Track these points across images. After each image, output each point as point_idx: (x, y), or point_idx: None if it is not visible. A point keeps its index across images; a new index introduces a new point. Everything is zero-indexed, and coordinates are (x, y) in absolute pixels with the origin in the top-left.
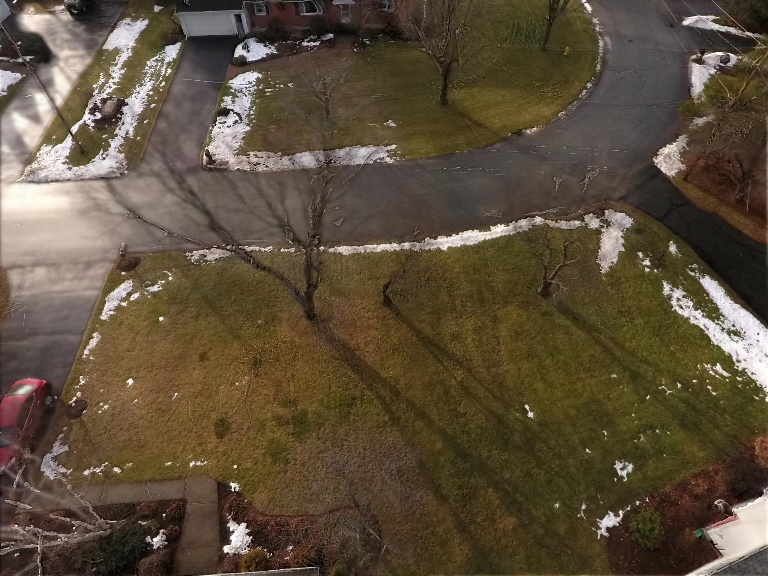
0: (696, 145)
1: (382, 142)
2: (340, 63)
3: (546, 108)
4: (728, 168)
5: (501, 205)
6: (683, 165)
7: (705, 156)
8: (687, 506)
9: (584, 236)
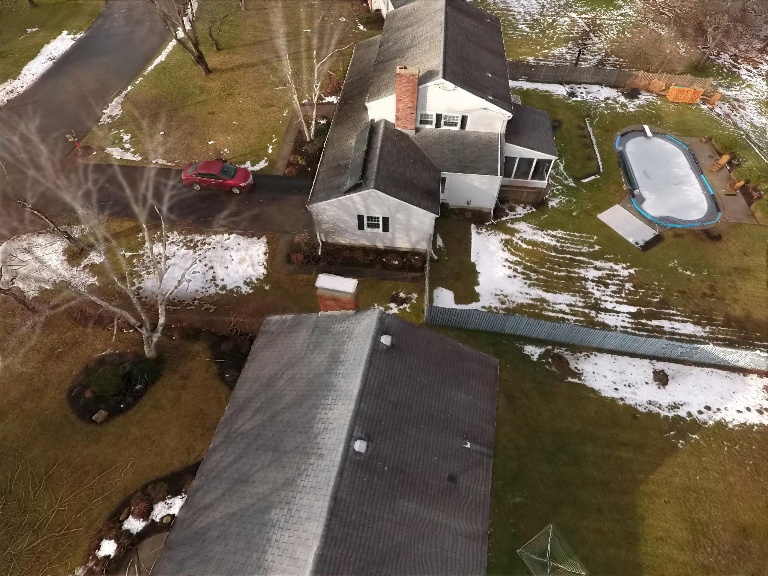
0: None
1: (53, 35)
2: None
3: None
4: None
5: (170, 7)
6: None
7: None
8: (362, 8)
9: None
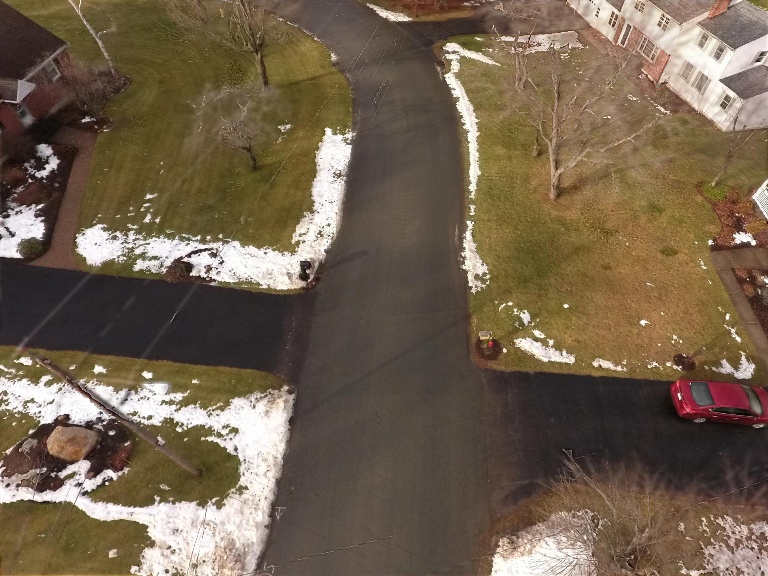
0: (380, 4)
1: (317, 136)
2: (129, 147)
3: (306, 43)
4: (410, 1)
5: (430, 87)
6: (400, 13)
7: (393, 4)
8: (650, 82)
9: (468, 62)
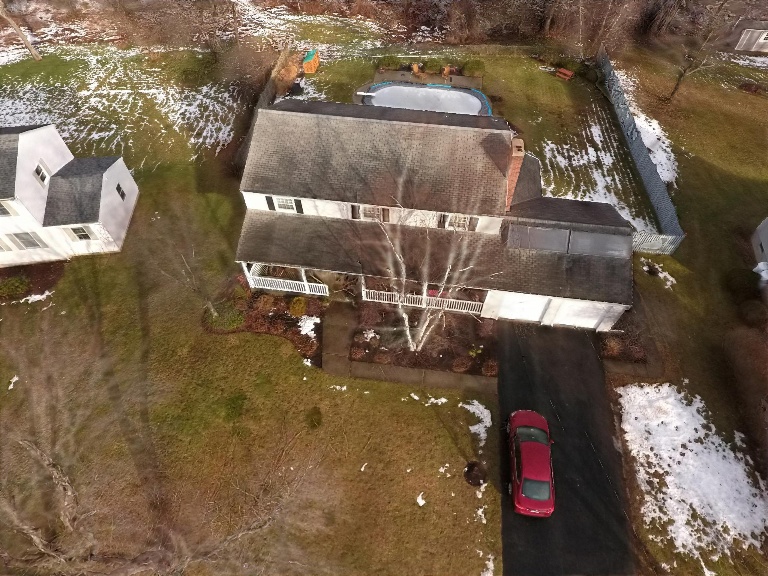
0: None
1: None
2: None
3: None
4: None
5: None
6: None
7: None
8: None
9: None
